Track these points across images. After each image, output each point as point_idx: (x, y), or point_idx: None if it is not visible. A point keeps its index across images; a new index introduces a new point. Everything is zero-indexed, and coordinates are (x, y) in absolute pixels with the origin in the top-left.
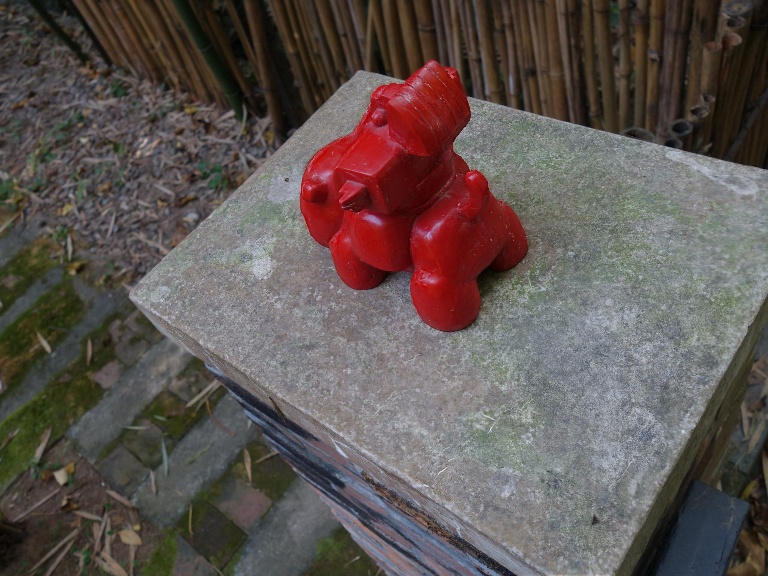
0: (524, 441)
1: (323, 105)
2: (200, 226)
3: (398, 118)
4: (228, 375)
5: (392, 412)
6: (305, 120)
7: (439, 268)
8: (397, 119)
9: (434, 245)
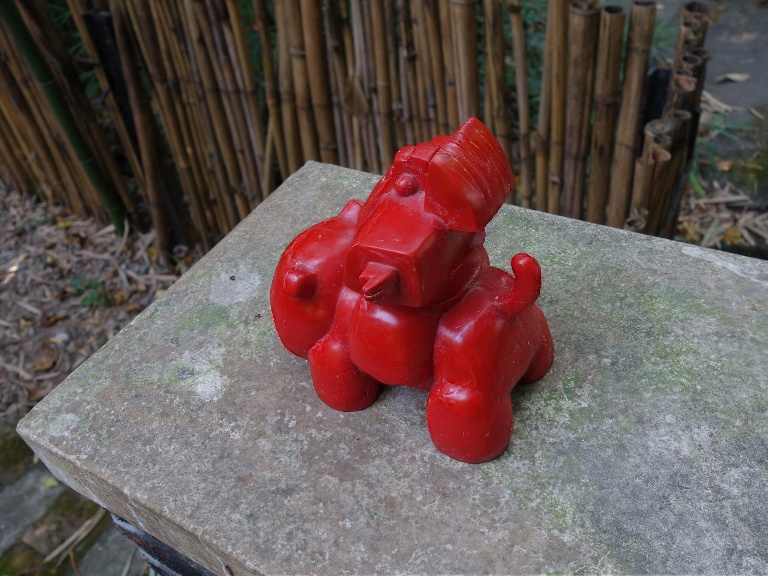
0: None
1: (270, 196)
2: (119, 334)
3: (444, 181)
4: (157, 534)
5: None
6: None
7: (474, 379)
8: (442, 182)
9: (468, 349)
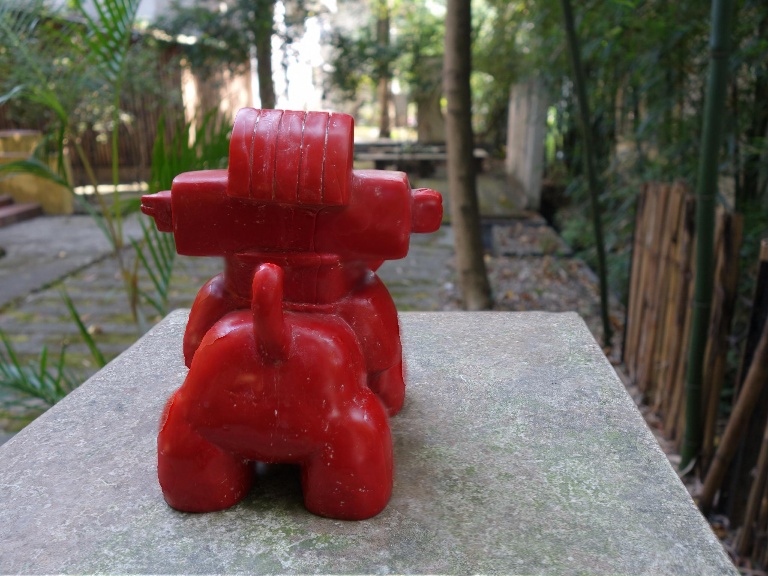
0: None
1: (500, 312)
2: None
3: None
4: None
5: (6, 497)
6: None
7: (187, 379)
8: None
9: None
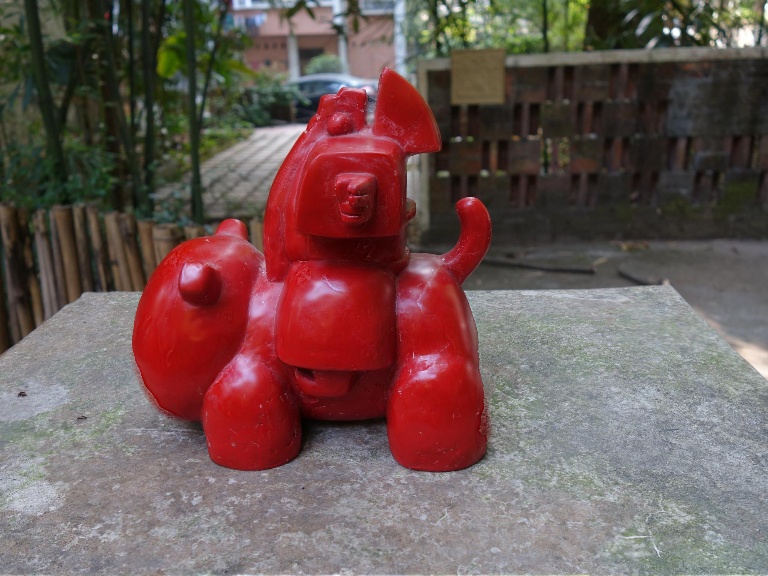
0: (715, 542)
1: (44, 323)
2: None
3: (400, 91)
4: None
5: None
6: (20, 338)
7: (452, 341)
8: (398, 93)
9: (436, 309)
